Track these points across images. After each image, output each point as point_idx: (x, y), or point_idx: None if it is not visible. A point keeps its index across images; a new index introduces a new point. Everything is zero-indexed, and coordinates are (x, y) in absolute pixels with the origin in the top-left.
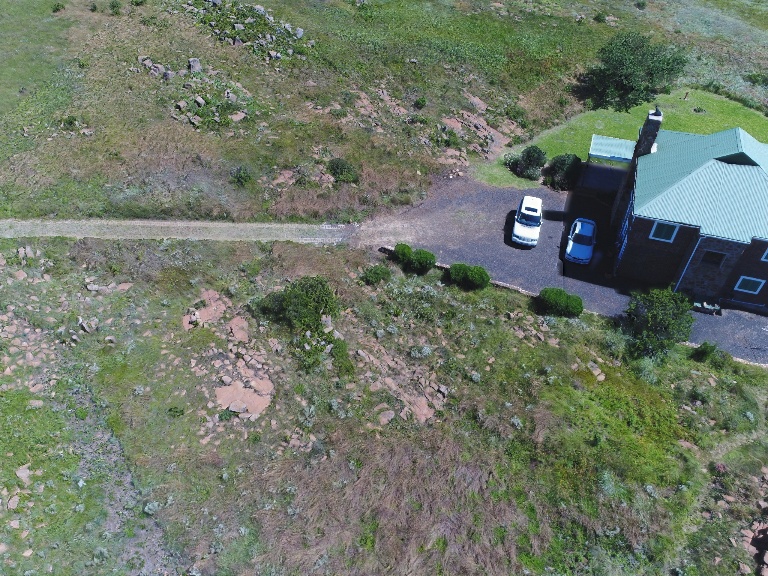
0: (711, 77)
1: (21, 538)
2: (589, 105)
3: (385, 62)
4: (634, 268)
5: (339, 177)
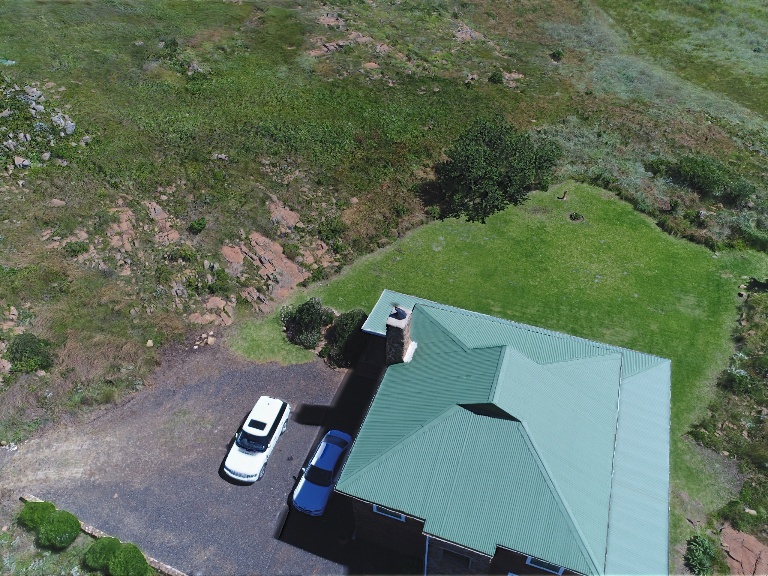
0: (605, 164)
1: None
2: (433, 214)
3: (184, 159)
4: (373, 535)
5: (15, 366)
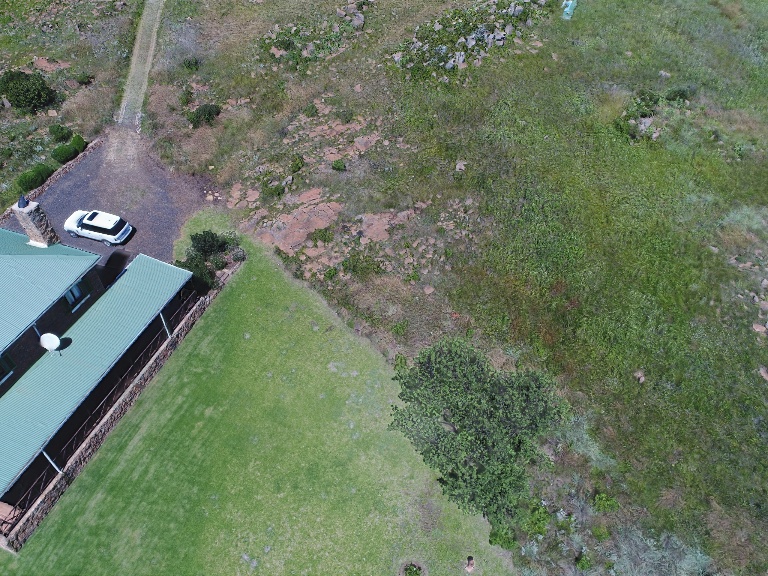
0: None
1: None
2: (397, 364)
3: None
4: None
5: None
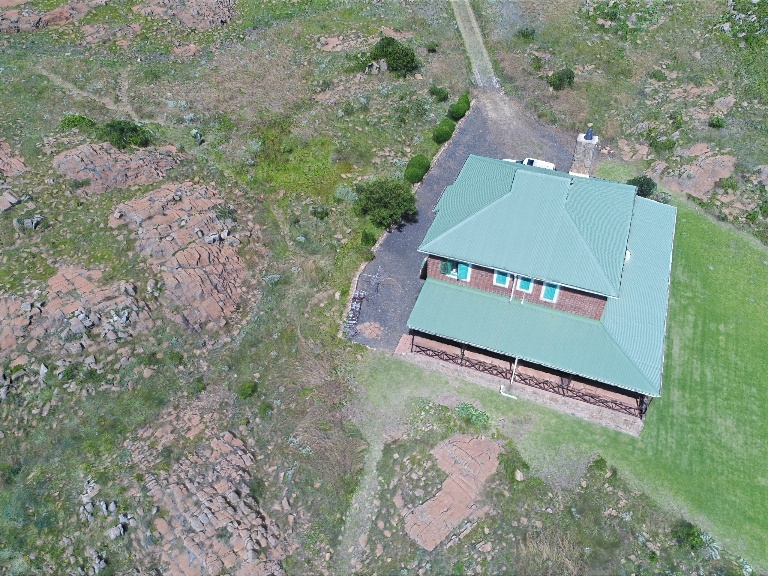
0: None
1: (268, 4)
2: None
3: None
4: None
5: None
